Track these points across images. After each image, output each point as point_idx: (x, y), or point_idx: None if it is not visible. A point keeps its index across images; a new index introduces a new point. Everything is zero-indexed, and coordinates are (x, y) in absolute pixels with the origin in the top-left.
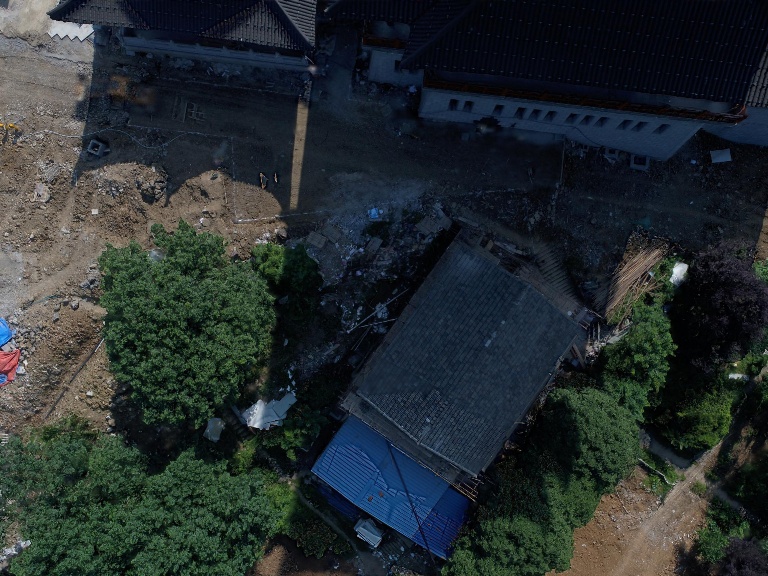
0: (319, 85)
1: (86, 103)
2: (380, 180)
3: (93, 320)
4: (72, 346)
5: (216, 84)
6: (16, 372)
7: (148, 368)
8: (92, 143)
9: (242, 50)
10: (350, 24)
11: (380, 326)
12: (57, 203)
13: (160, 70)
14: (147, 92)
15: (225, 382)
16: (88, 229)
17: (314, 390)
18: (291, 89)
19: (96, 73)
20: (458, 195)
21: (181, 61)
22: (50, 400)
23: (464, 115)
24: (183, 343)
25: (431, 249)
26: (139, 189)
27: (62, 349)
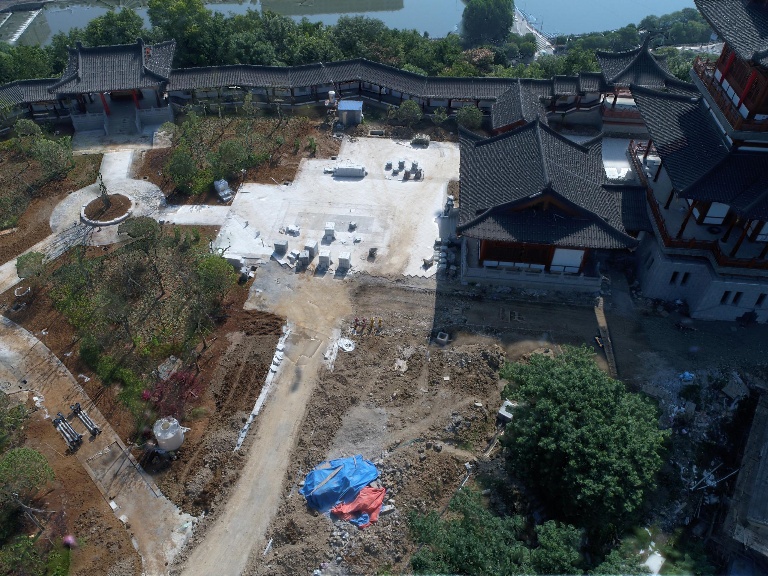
0: (608, 300)
1: (432, 311)
2: (679, 356)
3: (456, 461)
4: (439, 484)
5: (530, 300)
6: (381, 511)
7: (591, 426)
8: (440, 334)
9: (555, 274)
10: (617, 270)
11: (711, 496)
12: (414, 373)
13: (486, 293)
14: (478, 305)
15: (649, 459)
16: (443, 389)
17: (680, 547)
18: (587, 303)
19: (438, 295)
20: (749, 366)
21: (502, 288)
22: (411, 547)
23: (730, 311)
24: (611, 412)
25: (737, 418)
26: (485, 360)
27: (431, 485)
